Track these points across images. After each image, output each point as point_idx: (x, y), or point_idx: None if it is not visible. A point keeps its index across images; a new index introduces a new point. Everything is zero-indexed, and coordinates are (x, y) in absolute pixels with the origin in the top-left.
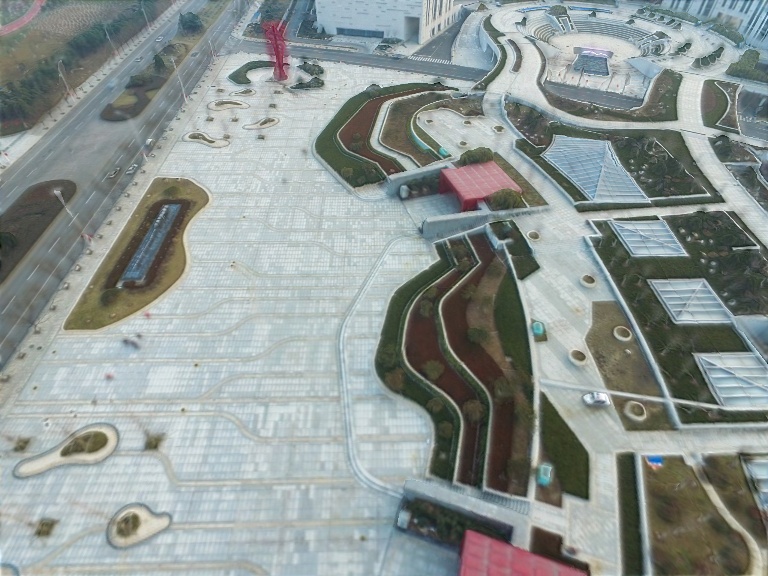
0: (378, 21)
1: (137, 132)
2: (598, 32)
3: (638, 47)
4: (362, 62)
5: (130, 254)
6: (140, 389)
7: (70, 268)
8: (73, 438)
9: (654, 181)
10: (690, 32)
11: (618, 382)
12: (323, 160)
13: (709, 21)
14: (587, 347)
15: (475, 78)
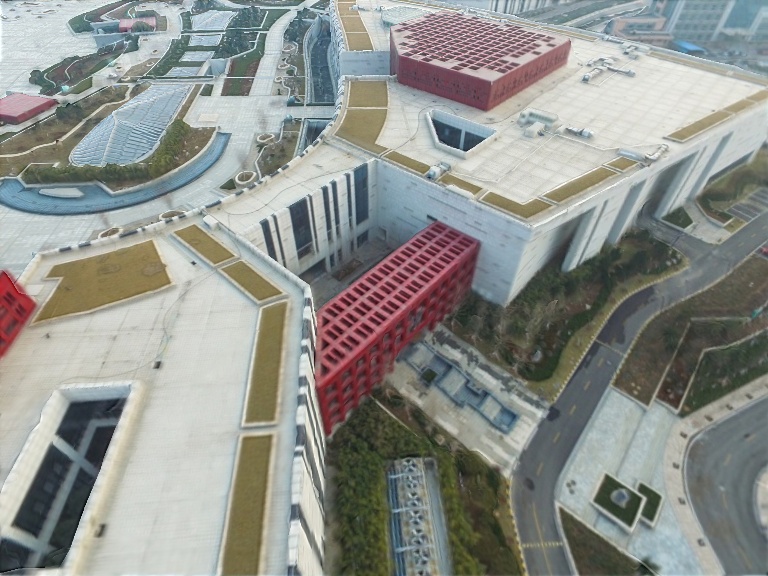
0: None
1: None
2: None
3: None
4: None
5: None
6: None
7: None
8: None
9: None
10: None
11: None
12: (69, 25)
13: None
14: (130, 68)
15: None
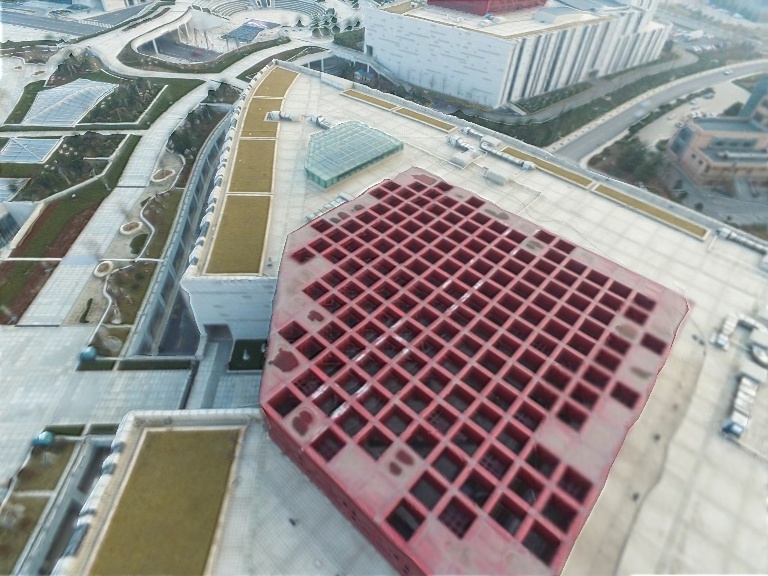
0: None
1: None
2: (293, 9)
3: None
4: (22, 22)
5: None
6: None
7: None
8: None
9: None
10: None
11: None
12: None
13: None
14: None
15: None
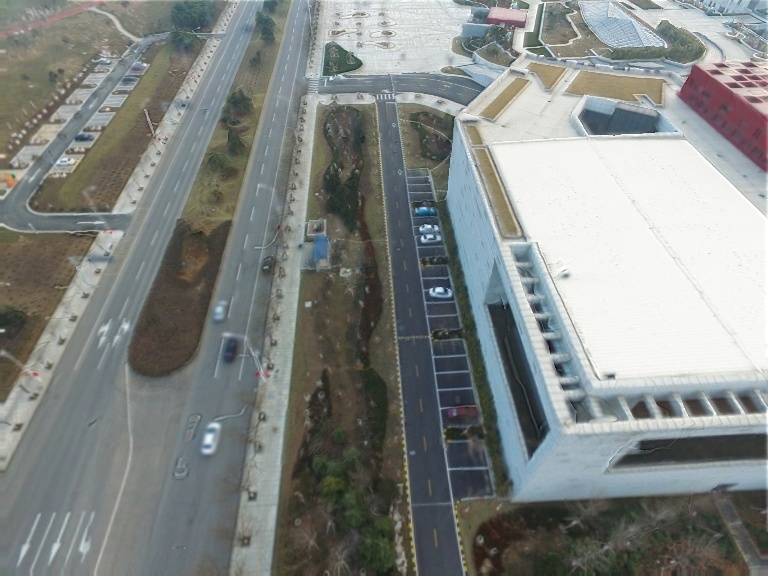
0: None
1: None
2: None
3: None
4: None
5: None
6: (369, 7)
7: None
8: None
9: None
10: None
11: None
12: None
13: None
14: None
15: None
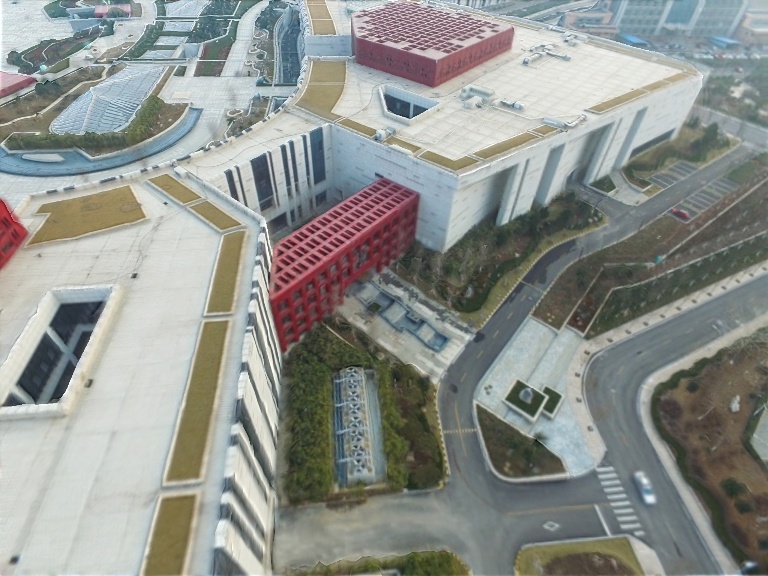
0: None
1: None
2: None
3: None
4: None
5: None
6: None
7: None
8: None
9: None
10: None
11: None
12: (44, 10)
13: None
14: None
15: None
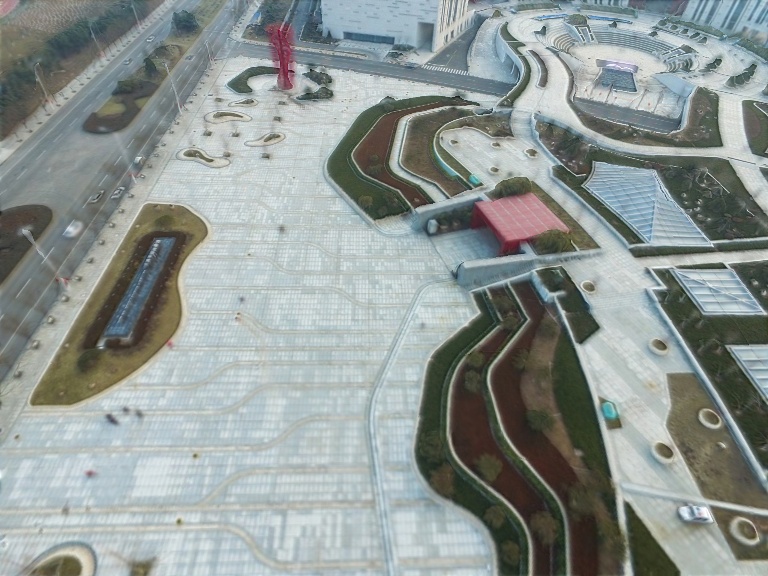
0: (389, 26)
1: (124, 147)
2: (619, 44)
3: (663, 61)
4: (373, 71)
5: (114, 302)
6: (125, 491)
7: (41, 320)
8: (37, 565)
9: (714, 221)
10: (716, 46)
11: (715, 487)
12: (337, 185)
13: (734, 35)
14: (670, 437)
15: (495, 91)
